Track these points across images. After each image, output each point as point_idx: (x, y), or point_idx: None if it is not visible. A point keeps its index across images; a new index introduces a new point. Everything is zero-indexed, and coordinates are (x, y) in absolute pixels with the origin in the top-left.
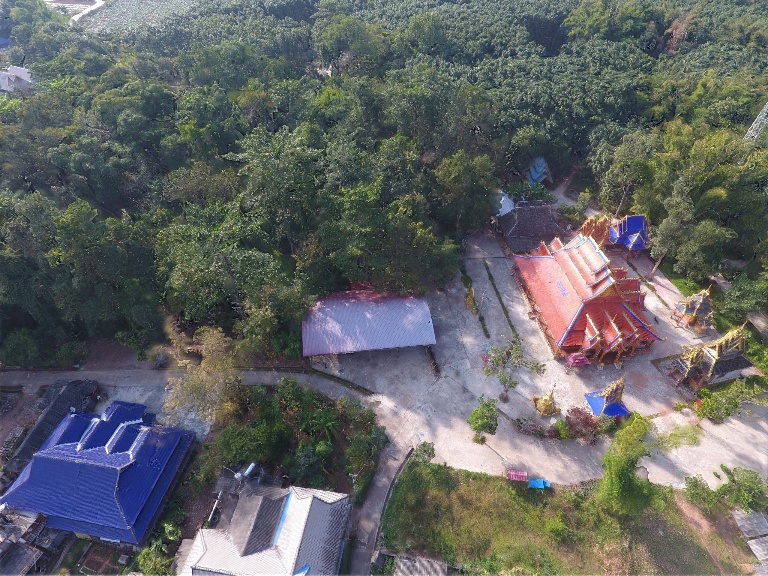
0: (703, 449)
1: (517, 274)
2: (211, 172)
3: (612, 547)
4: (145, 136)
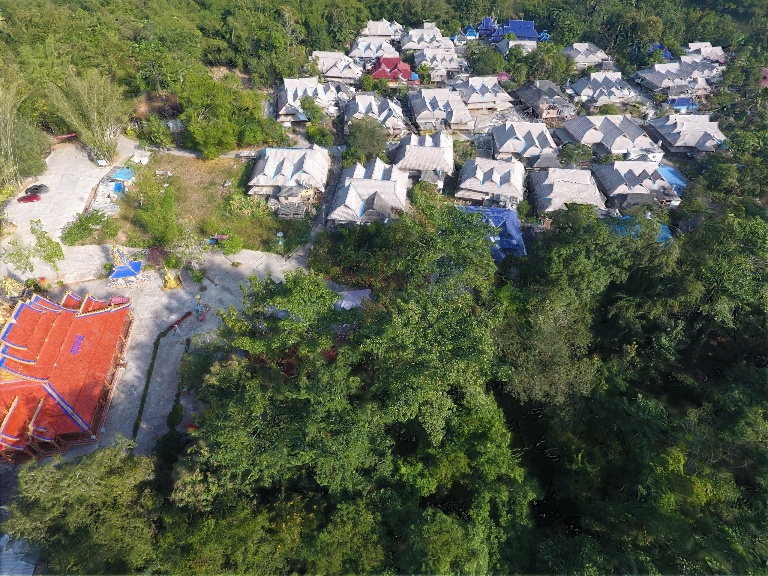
0: (74, 263)
1: (96, 428)
2: (614, 501)
3: (184, 220)
4: (765, 467)
